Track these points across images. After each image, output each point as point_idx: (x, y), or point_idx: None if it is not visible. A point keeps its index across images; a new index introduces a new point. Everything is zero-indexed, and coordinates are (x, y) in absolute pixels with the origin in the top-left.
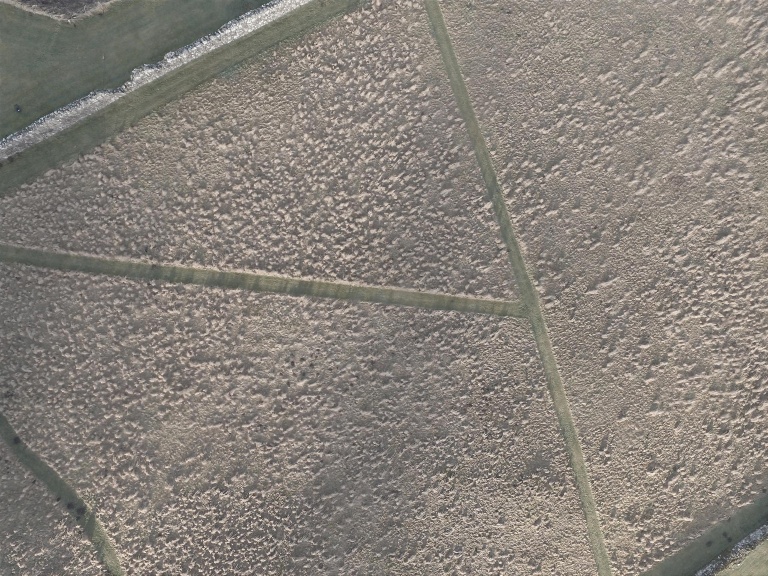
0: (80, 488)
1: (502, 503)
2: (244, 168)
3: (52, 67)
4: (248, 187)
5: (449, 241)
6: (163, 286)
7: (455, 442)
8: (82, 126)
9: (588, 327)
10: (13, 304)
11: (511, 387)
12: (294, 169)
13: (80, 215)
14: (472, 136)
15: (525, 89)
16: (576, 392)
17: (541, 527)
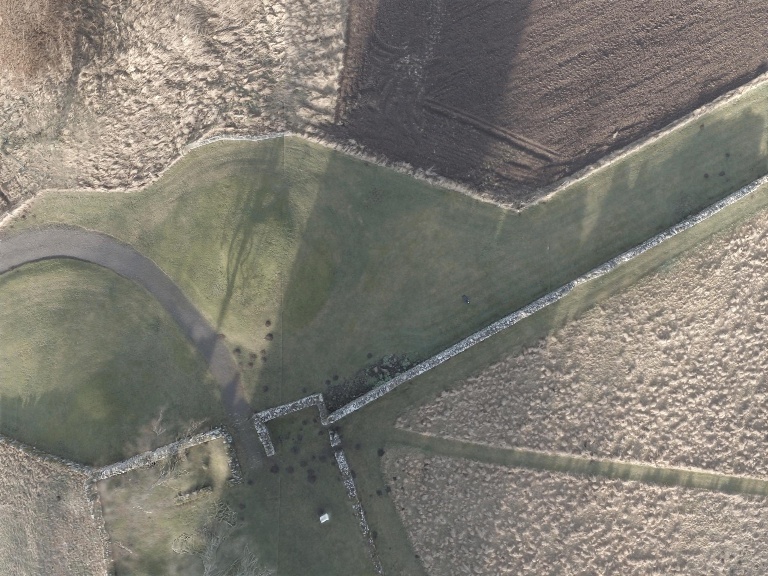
0: None
1: None
2: (681, 363)
3: (499, 257)
4: (683, 382)
5: None
6: (603, 482)
7: None
8: (526, 318)
9: None
10: (462, 502)
11: None
12: (726, 364)
13: (523, 409)
14: None
15: None
16: None
17: None
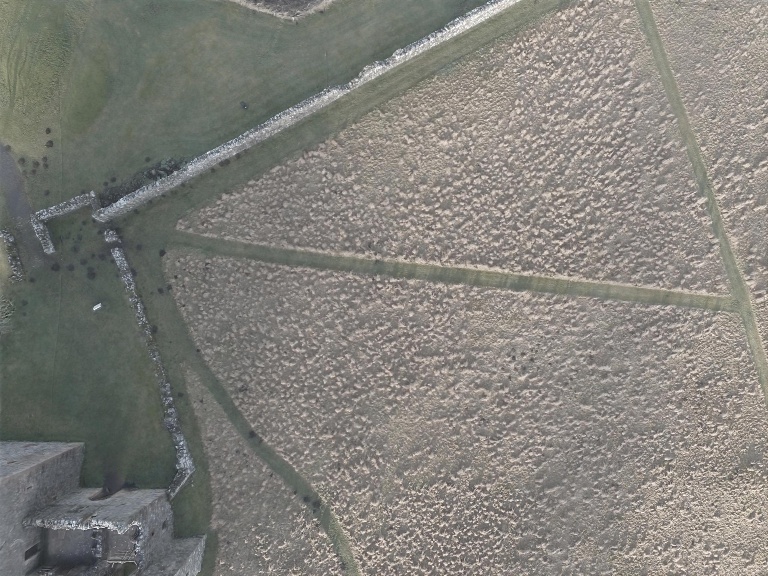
0: (315, 481)
1: (718, 496)
2: (464, 164)
3: (276, 64)
4: (468, 183)
5: (664, 236)
6: (387, 281)
7: (671, 436)
8: (306, 123)
9: None
10: (244, 299)
11: (724, 381)
12: (512, 165)
13: (305, 211)
14: (683, 132)
15: (733, 85)
16: None
17: (755, 520)
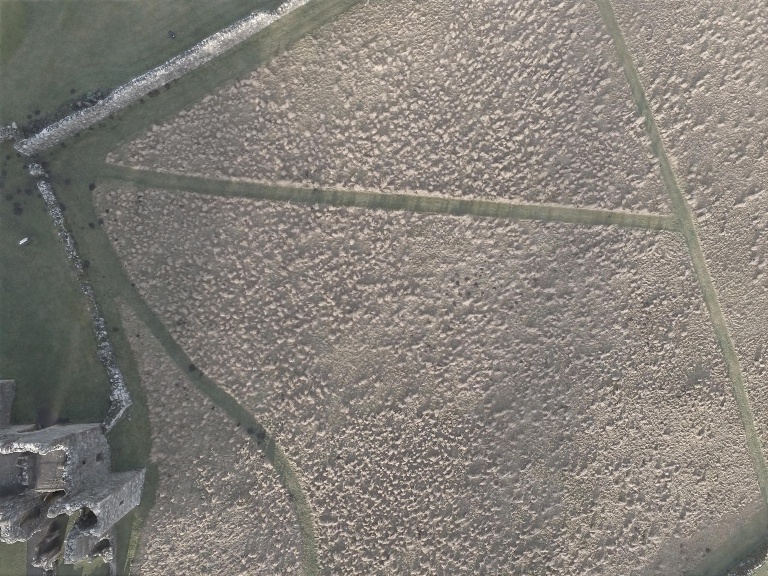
0: (259, 413)
1: (667, 414)
2: (400, 89)
3: None
4: (405, 108)
5: (604, 157)
6: (326, 210)
7: (619, 356)
8: (237, 51)
9: (738, 240)
10: (179, 232)
11: (669, 300)
12: (449, 89)
13: (239, 141)
14: (619, 53)
15: (667, 5)
16: (730, 304)
17: (704, 437)
